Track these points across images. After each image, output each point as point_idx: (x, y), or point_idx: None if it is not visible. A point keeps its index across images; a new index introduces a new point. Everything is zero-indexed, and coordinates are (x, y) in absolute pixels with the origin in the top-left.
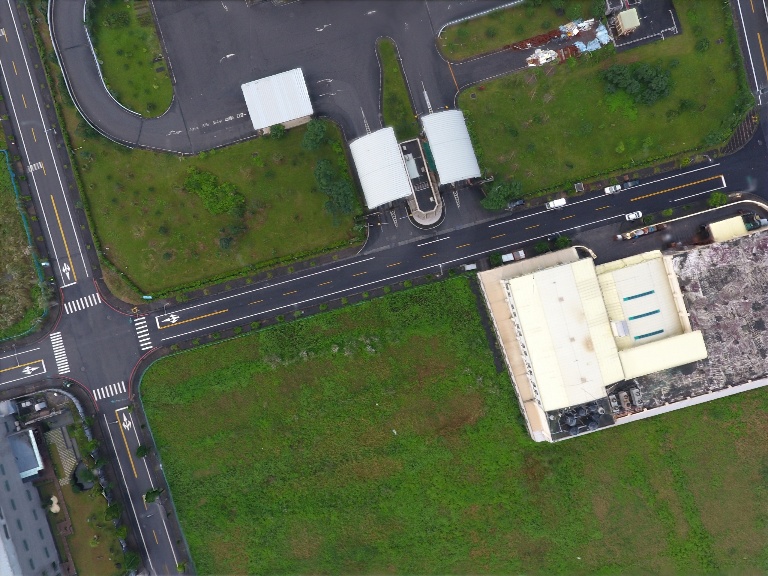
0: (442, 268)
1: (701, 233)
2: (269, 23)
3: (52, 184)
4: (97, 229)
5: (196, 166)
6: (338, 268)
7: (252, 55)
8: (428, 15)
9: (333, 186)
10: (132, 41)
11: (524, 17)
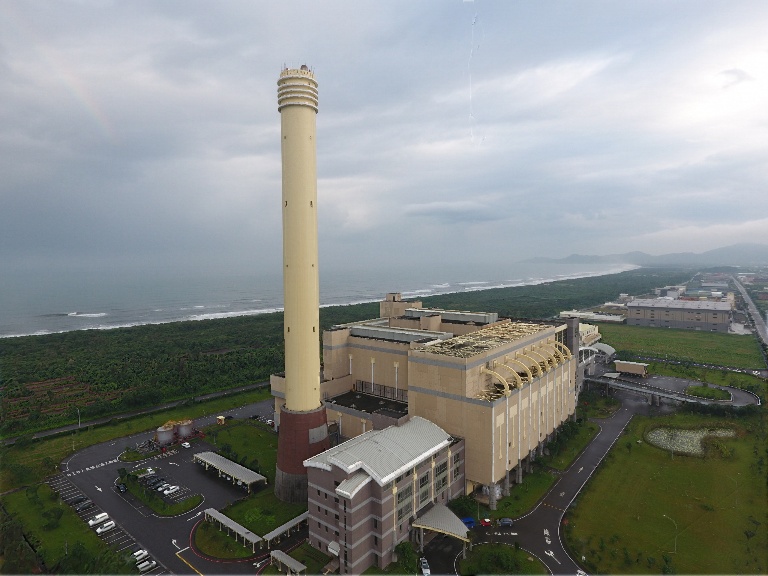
0: None
1: None
2: None
3: None
4: None
5: None
6: None
7: None
8: None
9: None
10: None
11: None
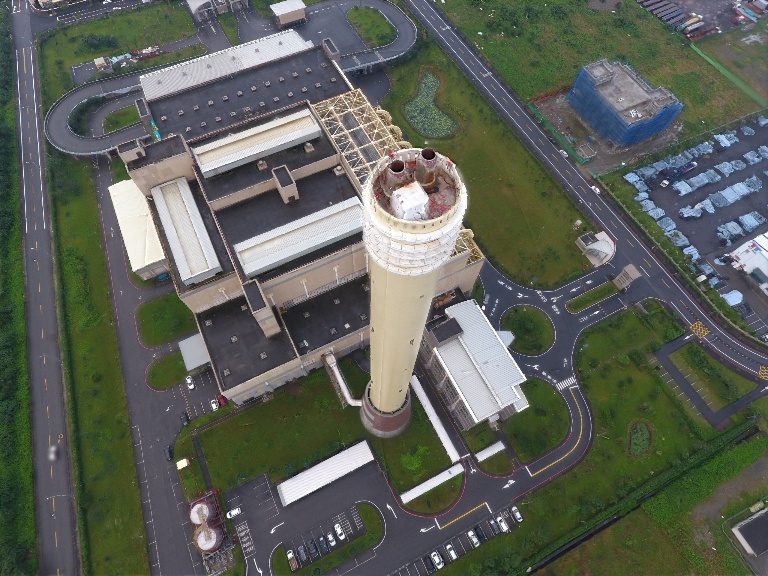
0: None
1: (74, 1)
2: None
3: None
4: None
5: None
6: None
7: (308, 34)
8: None
9: None
10: (373, 31)
11: (159, 63)
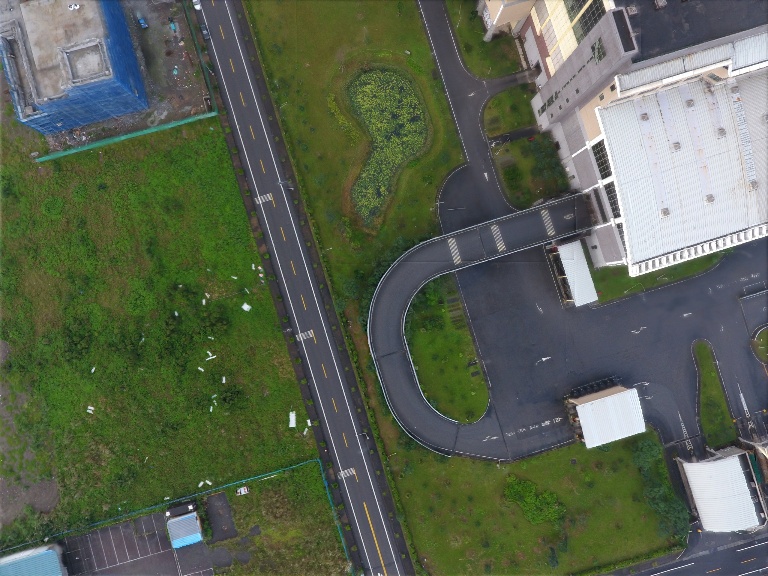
0: (762, 573)
1: None
2: (585, 326)
3: (364, 491)
4: (413, 538)
5: (515, 474)
6: (657, 575)
7: (568, 358)
8: (743, 316)
9: (669, 508)
10: (447, 345)
11: None
